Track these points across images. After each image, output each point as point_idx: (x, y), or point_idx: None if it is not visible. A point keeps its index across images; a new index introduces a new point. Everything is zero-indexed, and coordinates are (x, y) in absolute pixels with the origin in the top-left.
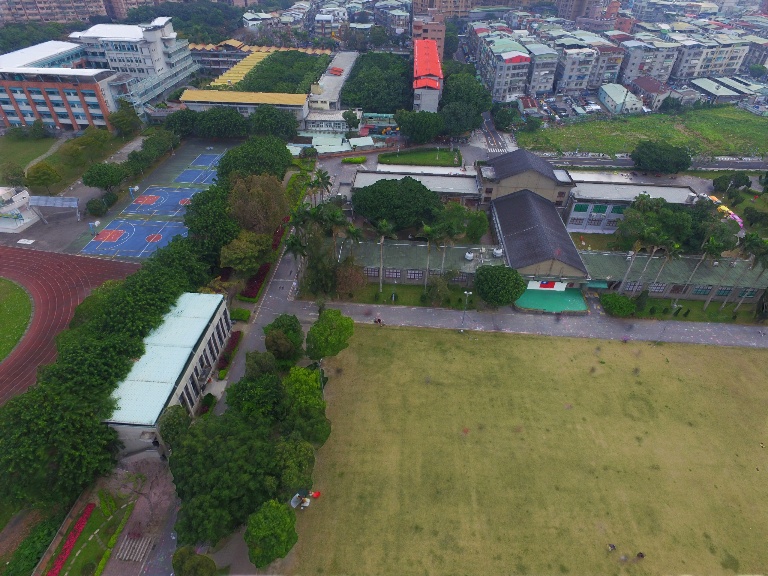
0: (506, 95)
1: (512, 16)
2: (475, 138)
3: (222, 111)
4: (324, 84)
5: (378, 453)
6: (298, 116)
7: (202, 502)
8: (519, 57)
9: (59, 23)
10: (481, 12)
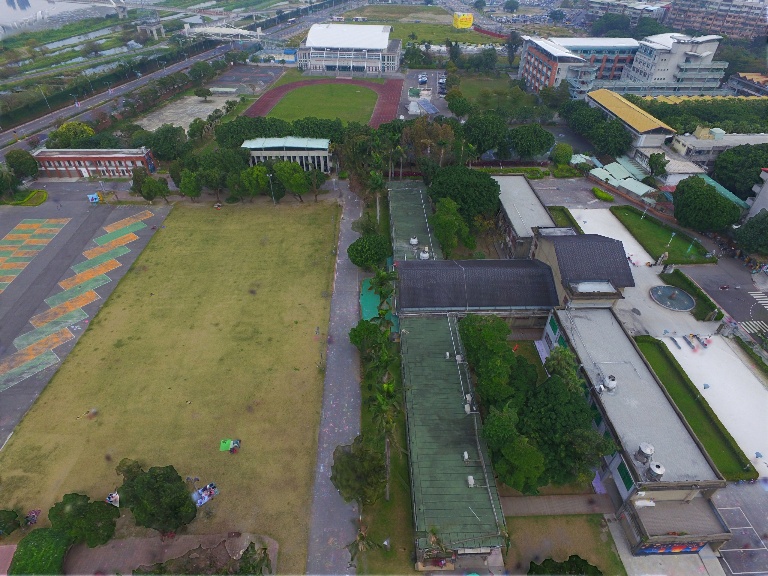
0: None
1: None
2: None
3: (592, 111)
4: (740, 138)
5: (236, 223)
6: (635, 142)
7: (193, 155)
8: None
9: (731, 37)
10: None
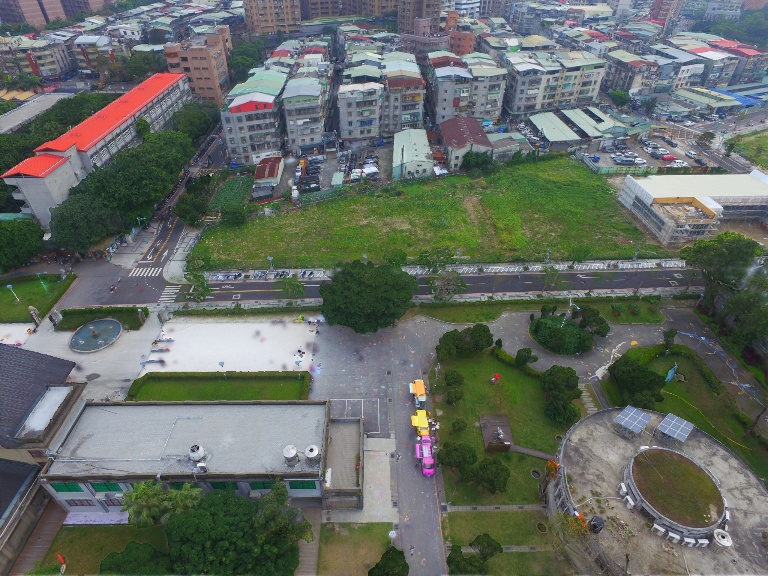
0: (250, 155)
1: (338, 31)
2: (133, 245)
3: None
4: None
5: None
6: None
7: None
8: (252, 103)
9: None
10: (317, 25)
